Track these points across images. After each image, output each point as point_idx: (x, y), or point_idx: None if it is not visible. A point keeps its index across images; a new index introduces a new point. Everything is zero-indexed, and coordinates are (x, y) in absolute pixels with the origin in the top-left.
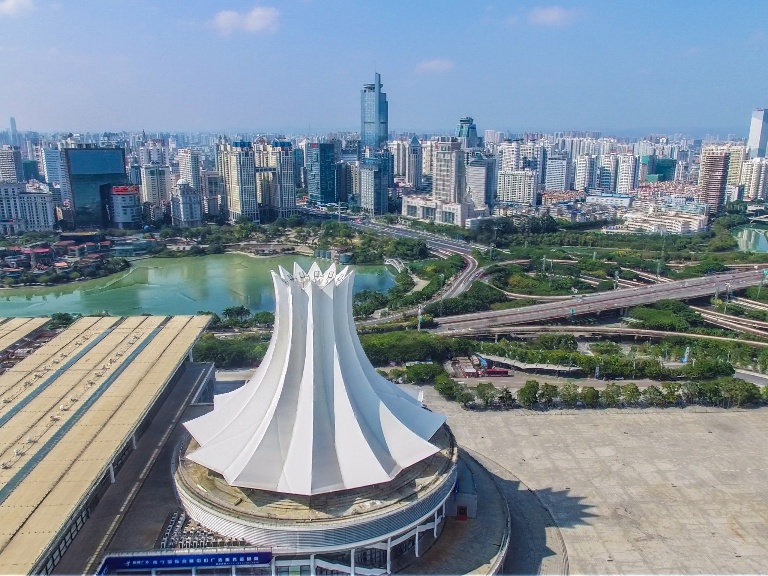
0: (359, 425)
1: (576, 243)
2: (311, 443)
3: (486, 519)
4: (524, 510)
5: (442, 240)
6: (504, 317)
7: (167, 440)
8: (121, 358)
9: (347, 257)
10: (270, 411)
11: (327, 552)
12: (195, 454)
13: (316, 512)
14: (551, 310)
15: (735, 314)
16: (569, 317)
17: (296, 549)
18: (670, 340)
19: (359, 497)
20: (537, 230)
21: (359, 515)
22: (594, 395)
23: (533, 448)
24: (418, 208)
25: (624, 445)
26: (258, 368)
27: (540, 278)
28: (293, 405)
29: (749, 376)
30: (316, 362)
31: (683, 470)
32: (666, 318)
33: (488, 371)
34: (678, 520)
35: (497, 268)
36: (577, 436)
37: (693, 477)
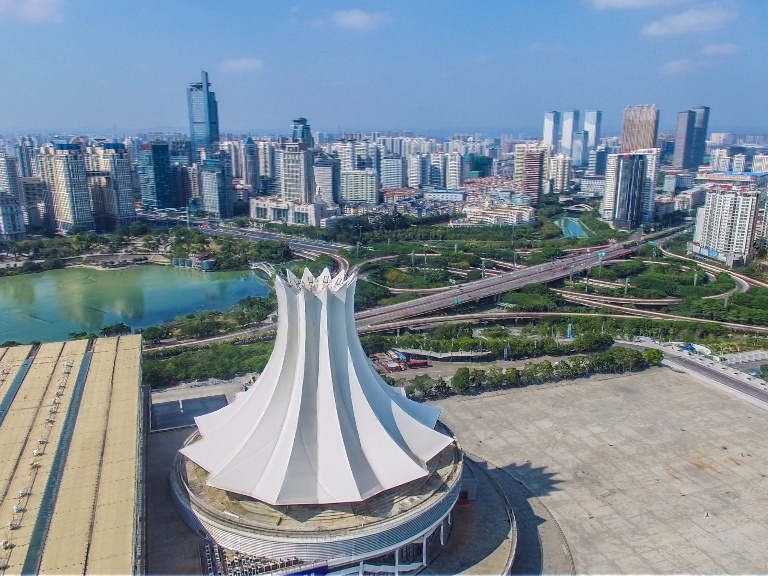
0: (382, 426)
1: (428, 237)
2: (344, 450)
3: (486, 499)
4: (502, 487)
5: (301, 241)
6: (396, 312)
7: (146, 473)
8: (67, 390)
9: (210, 264)
10: (289, 424)
11: (380, 555)
12: (216, 480)
13: (363, 517)
14: (437, 301)
15: (588, 292)
16: (454, 307)
17: (351, 557)
18: (548, 320)
19: (396, 496)
20: (391, 227)
21: (405, 513)
22: (517, 375)
23: (483, 430)
24: (268, 210)
25: (557, 416)
26: (260, 382)
27: (412, 272)
28: (313, 415)
29: (623, 344)
30: (332, 368)
31: (612, 431)
32: (536, 300)
33: (410, 364)
34: (627, 474)
35: (371, 265)
36: (515, 414)
37: (622, 435)
